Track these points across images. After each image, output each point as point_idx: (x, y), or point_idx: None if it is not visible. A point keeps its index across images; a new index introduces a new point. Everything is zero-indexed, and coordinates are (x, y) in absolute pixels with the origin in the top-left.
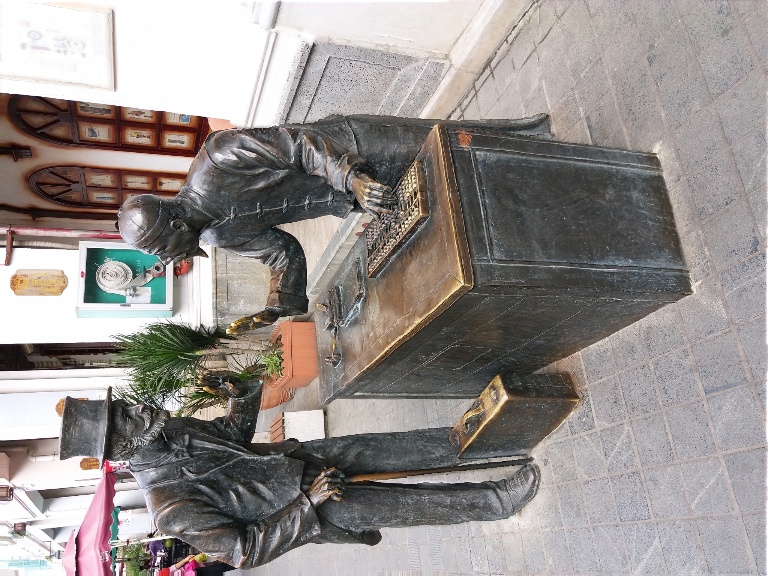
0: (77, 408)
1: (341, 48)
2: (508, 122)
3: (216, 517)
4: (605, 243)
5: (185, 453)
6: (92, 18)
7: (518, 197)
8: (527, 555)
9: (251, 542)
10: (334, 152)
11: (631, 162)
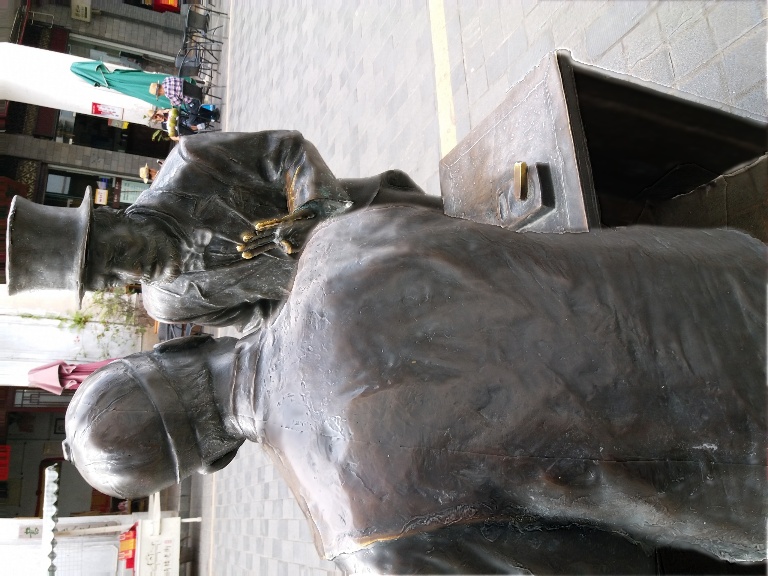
0: (30, 280)
1: None
2: None
3: None
4: None
5: (200, 263)
6: None
7: None
8: None
9: (253, 327)
10: None
11: None
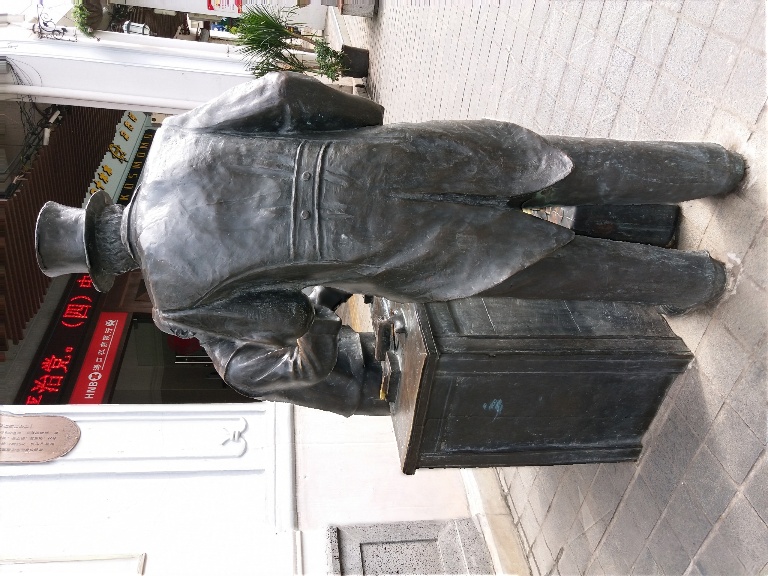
0: None
1: (366, 531)
2: None
3: None
4: None
5: None
6: (124, 568)
7: None
8: (763, 88)
9: None
10: None
11: None
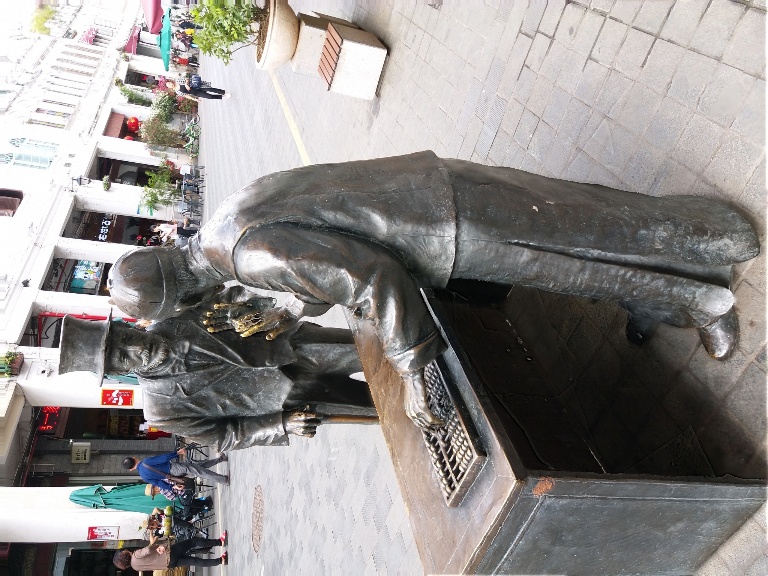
0: (74, 350)
1: None
2: (694, 250)
3: (200, 429)
4: (624, 567)
5: (182, 366)
6: None
7: (561, 538)
8: None
9: (227, 443)
10: (401, 335)
11: (738, 498)
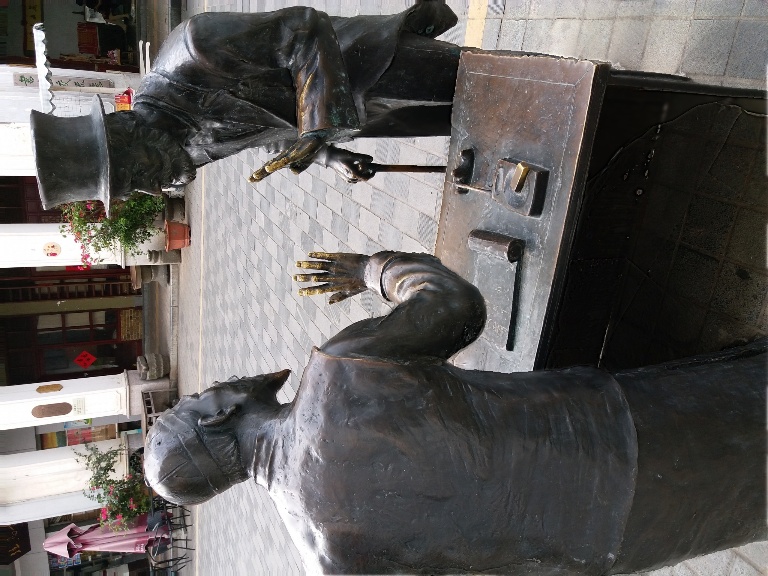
0: (60, 200)
1: None
2: None
3: None
4: None
5: (208, 139)
6: None
7: None
8: None
9: None
10: None
11: None
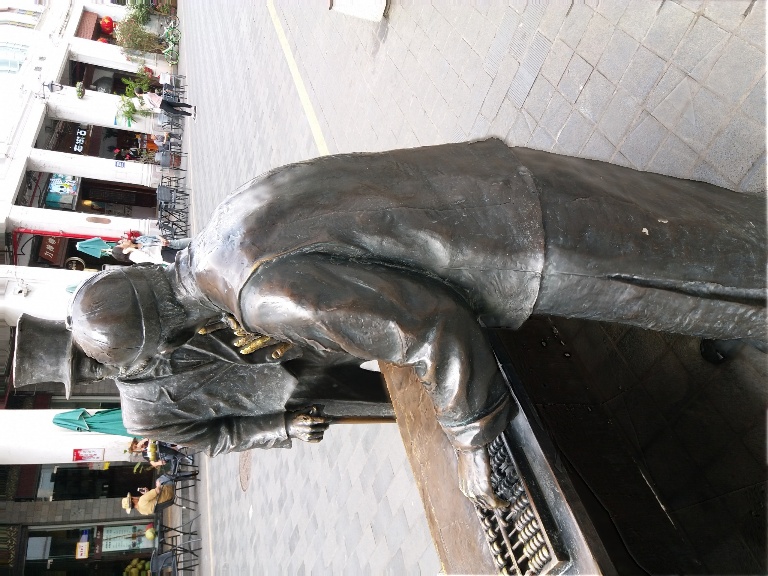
0: (32, 362)
1: None
2: None
3: (190, 435)
4: None
5: (167, 367)
6: None
7: None
8: None
9: (221, 447)
10: (465, 404)
11: None
